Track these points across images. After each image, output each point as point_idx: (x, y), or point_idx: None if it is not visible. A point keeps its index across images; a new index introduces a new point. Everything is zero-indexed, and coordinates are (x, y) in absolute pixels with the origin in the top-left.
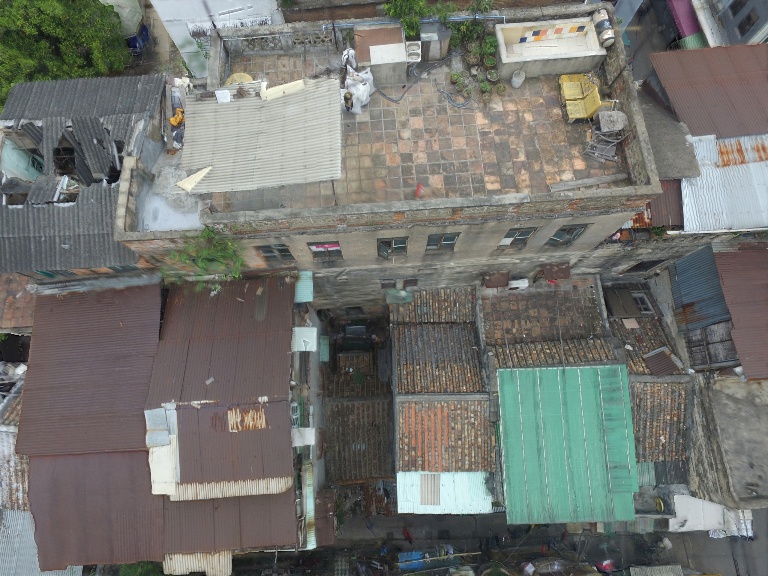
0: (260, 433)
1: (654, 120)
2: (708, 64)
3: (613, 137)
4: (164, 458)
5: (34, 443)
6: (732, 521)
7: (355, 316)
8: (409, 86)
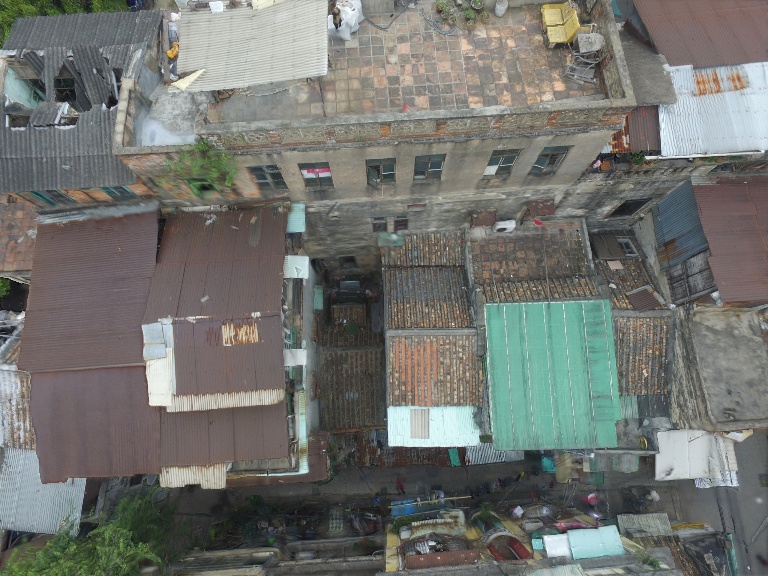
0: (253, 347)
1: (634, 53)
2: (687, 2)
3: (591, 59)
4: (161, 371)
5: (36, 360)
6: (717, 469)
7: (349, 270)
8: (397, 15)
